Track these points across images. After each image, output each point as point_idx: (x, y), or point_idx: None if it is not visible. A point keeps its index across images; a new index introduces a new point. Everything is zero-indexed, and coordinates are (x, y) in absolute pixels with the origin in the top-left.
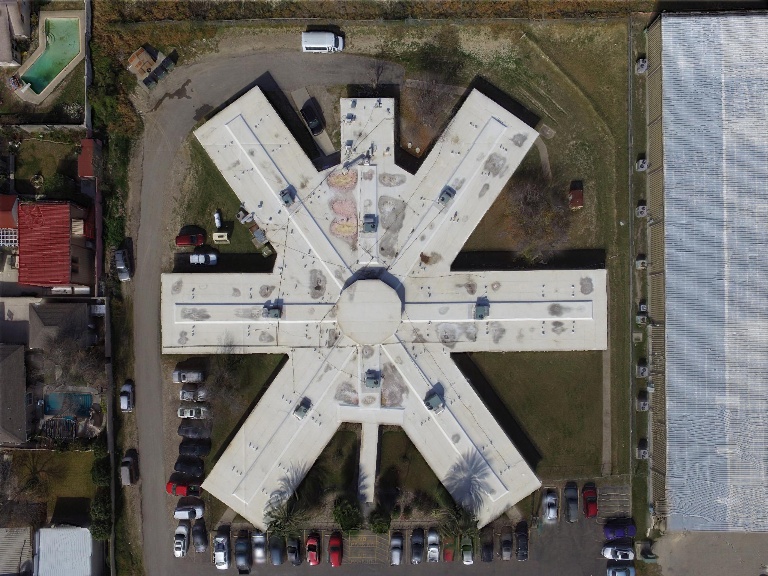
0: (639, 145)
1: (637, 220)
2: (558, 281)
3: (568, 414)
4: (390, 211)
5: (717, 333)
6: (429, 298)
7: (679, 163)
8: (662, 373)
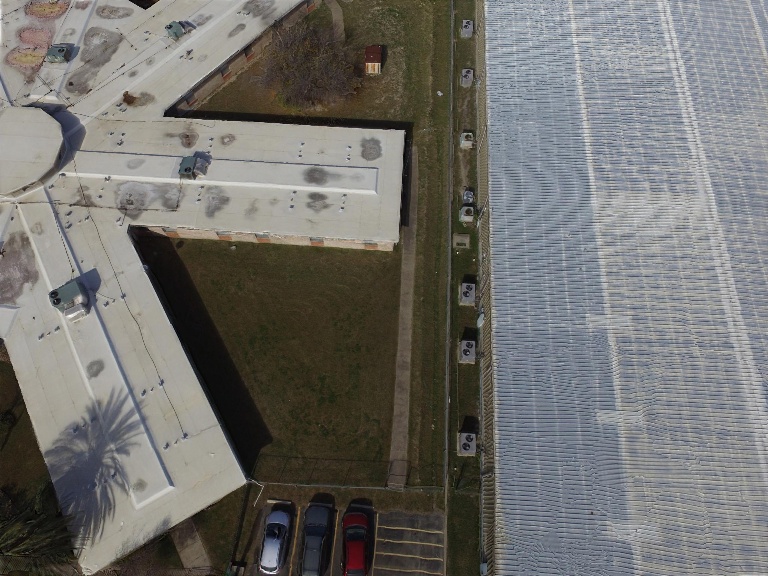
0: (466, 12)
1: (462, 90)
2: (327, 140)
3: (332, 358)
4: (99, 43)
5: (579, 211)
6: (119, 147)
7: (506, 2)
8: (488, 275)
